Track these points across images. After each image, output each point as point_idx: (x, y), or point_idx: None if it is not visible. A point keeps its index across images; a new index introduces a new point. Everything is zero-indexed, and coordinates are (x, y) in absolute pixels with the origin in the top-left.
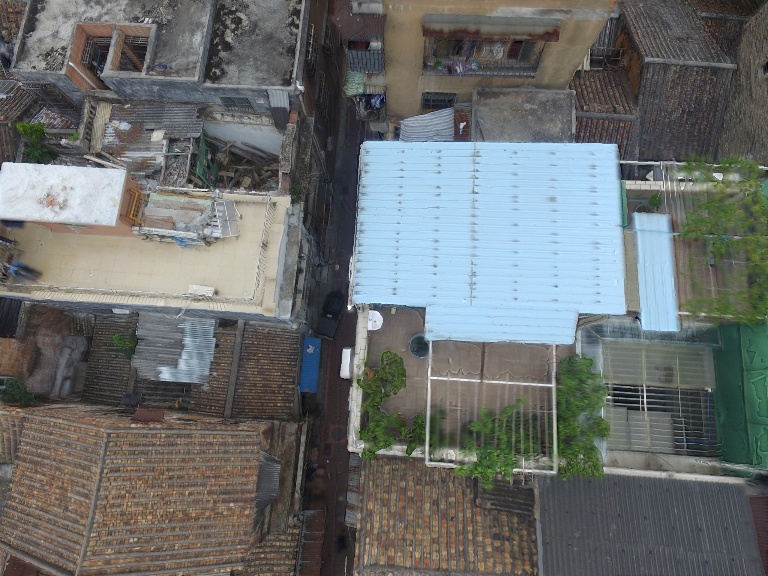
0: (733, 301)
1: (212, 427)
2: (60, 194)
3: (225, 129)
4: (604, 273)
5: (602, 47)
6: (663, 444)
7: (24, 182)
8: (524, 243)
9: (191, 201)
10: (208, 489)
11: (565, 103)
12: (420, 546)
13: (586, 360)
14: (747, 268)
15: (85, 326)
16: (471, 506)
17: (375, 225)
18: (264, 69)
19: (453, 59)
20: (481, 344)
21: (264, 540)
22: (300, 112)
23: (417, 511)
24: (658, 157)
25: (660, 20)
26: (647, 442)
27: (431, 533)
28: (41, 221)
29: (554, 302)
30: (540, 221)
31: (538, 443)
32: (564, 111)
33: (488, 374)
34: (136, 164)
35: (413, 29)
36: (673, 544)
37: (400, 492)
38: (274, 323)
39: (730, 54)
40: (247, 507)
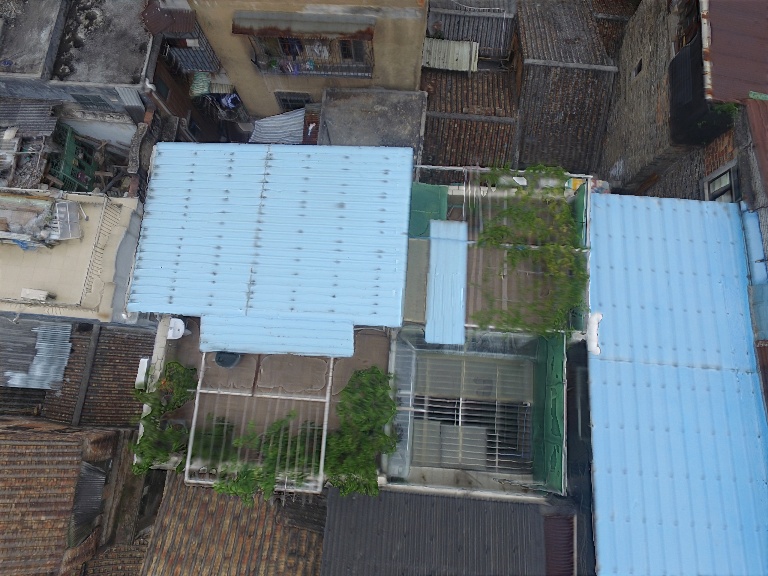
0: (522, 313)
1: (26, 437)
2: None
3: (94, 127)
4: (383, 283)
5: (490, 48)
6: (474, 460)
7: None
8: (306, 251)
9: (29, 202)
10: (16, 502)
11: (416, 104)
12: (209, 566)
13: (372, 374)
14: (540, 279)
15: None
16: (272, 524)
17: (159, 230)
18: (115, 66)
19: (283, 57)
20: (257, 356)
21: (101, 553)
22: (159, 111)
23: (214, 528)
24: (541, 161)
25: (553, 21)
26: (458, 458)
27: (224, 552)
28: None
29: (330, 313)
30: (324, 228)
31: (304, 461)
32: (415, 113)
33: (299, 386)
34: None
35: (230, 26)
36: (456, 567)
37: (201, 508)
38: (135, 328)
39: (614, 56)
40: (61, 521)
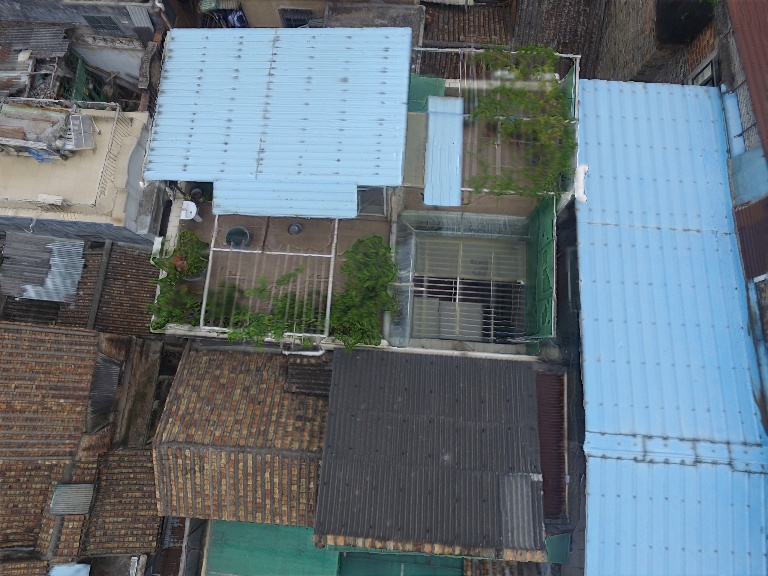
0: (515, 178)
1: None
2: None
3: (103, 56)
4: (384, 147)
5: None
6: (471, 333)
7: None
8: (311, 120)
9: (44, 113)
10: (36, 384)
11: (415, 18)
12: (222, 426)
13: (375, 237)
14: (532, 147)
15: None
16: (280, 392)
17: (173, 106)
18: None
19: None
20: (266, 218)
21: (115, 449)
22: None
23: (226, 396)
24: None
25: None
26: (456, 331)
27: (235, 415)
28: None
29: (335, 175)
30: (329, 100)
31: (311, 309)
32: (413, 26)
33: None
34: (1, 83)
35: None
36: (454, 415)
37: (213, 379)
38: (145, 245)
39: None
40: (79, 404)
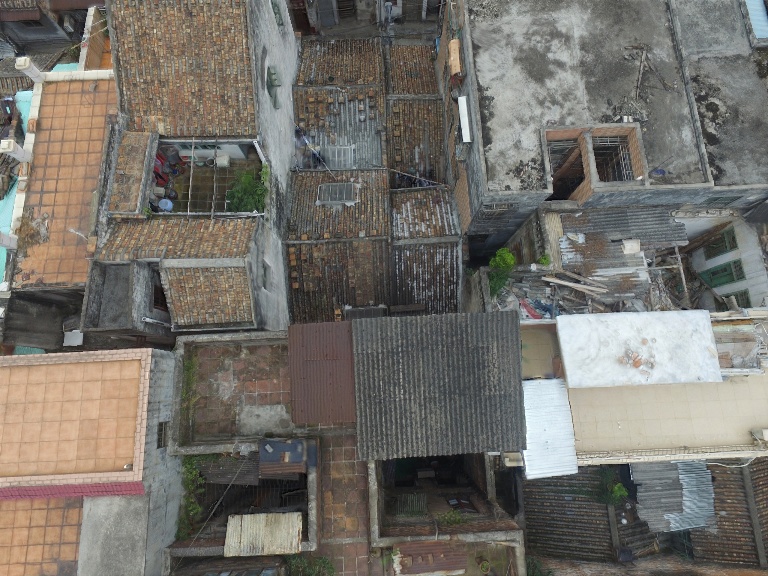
0: None
1: None
2: (643, 349)
3: None
4: None
5: None
6: None
7: (593, 338)
8: None
9: (738, 329)
10: None
11: None
12: None
13: None
14: None
15: (499, 460)
16: None
17: None
18: (766, 162)
19: None
20: None
21: None
22: None
23: None
24: None
25: None
26: None
27: None
28: (631, 385)
29: None
30: None
31: None
32: None
33: None
34: (617, 284)
35: None
36: None
37: None
38: None
39: None
40: None
